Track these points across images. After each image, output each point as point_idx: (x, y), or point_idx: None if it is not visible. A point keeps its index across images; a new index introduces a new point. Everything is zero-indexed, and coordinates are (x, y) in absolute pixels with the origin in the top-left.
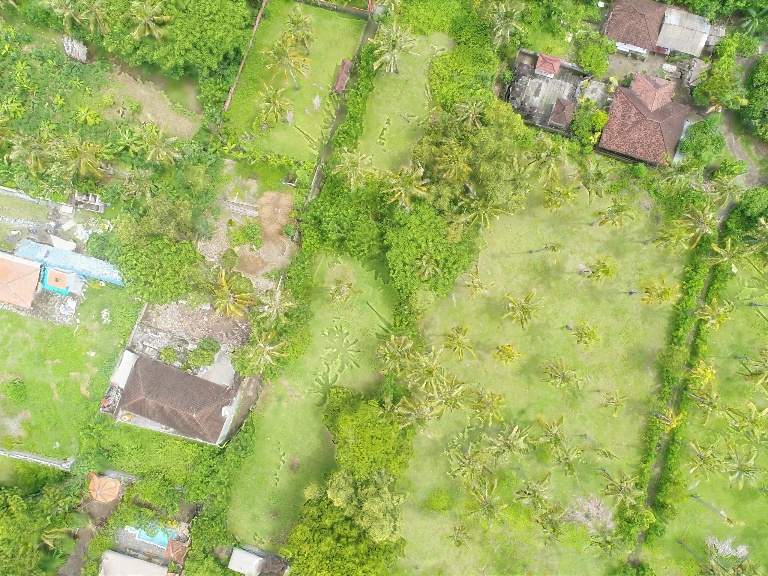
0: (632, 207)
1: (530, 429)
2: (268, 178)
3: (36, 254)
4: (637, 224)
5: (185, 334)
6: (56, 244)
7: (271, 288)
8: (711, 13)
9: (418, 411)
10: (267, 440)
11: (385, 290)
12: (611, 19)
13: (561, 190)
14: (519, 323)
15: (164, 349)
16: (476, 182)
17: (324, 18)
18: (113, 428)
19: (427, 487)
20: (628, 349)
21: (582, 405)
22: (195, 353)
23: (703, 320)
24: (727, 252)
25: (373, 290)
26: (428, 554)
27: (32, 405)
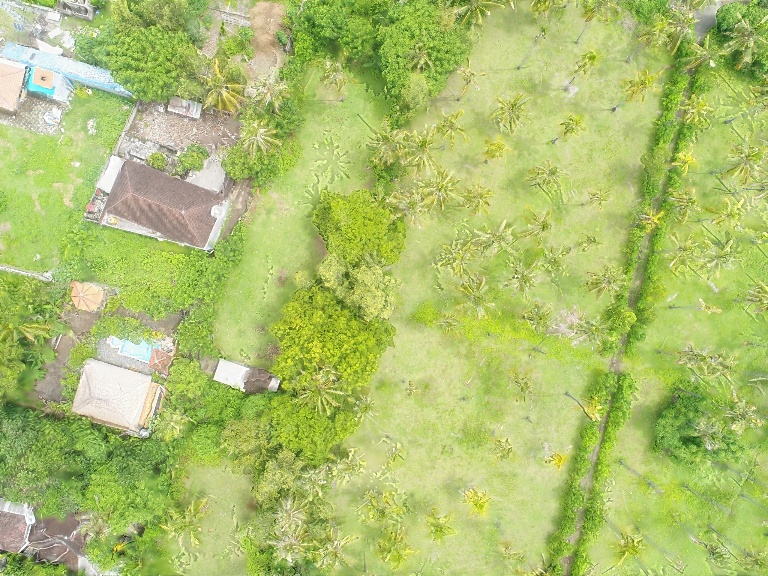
0: (615, 27)
1: (516, 242)
2: None
3: (21, 56)
4: (620, 44)
5: (173, 145)
6: (42, 48)
7: None
8: None
9: None
10: (255, 253)
11: (376, 102)
12: None
13: None
14: (506, 138)
15: (152, 153)
16: None
17: None
18: (97, 239)
19: (415, 300)
20: (610, 164)
21: (566, 219)
22: (185, 154)
23: (681, 133)
24: (706, 49)
25: (364, 103)
26: (415, 368)
27: (12, 216)
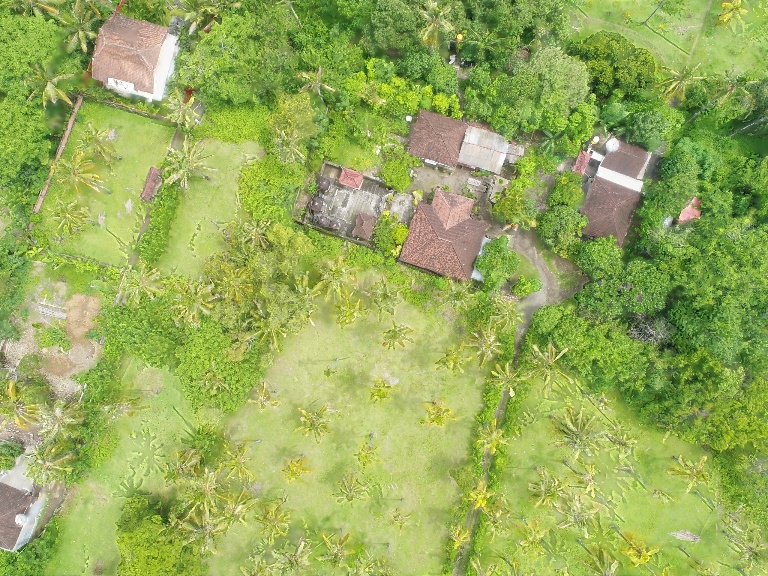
0: (436, 318)
1: (334, 536)
2: (76, 281)
3: None
4: (441, 335)
5: None
6: None
7: (78, 391)
8: (507, 134)
9: (202, 527)
10: (72, 543)
11: None
12: (414, 136)
13: (346, 310)
14: None
15: None
16: (264, 300)
17: (138, 123)
18: None
19: None
20: (431, 458)
21: (386, 513)
22: None
23: None
24: (506, 375)
25: (181, 394)
26: None
27: None
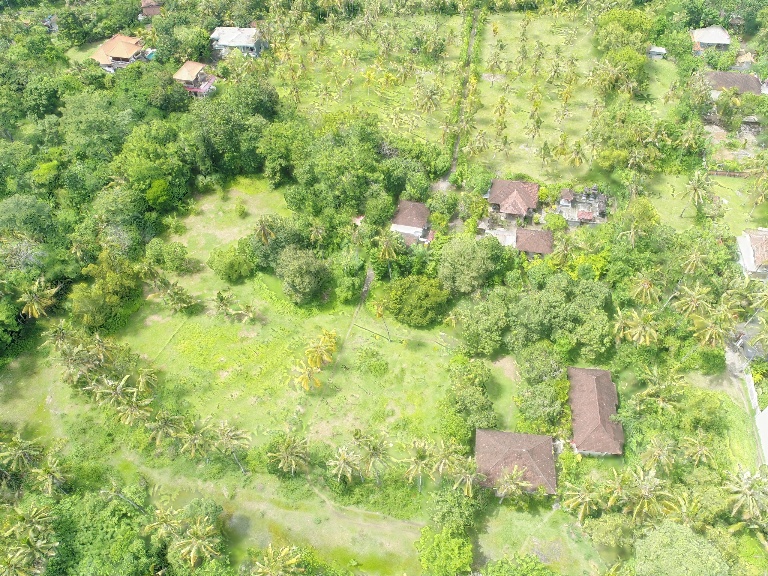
0: None
1: None
2: None
3: None
4: None
5: None
6: None
7: None
8: None
9: None
10: None
11: None
12: None
13: None
14: None
15: None
16: None
17: None
18: None
19: None
20: None
21: (509, 106)
22: None
23: None
24: None
25: None
26: None
27: None
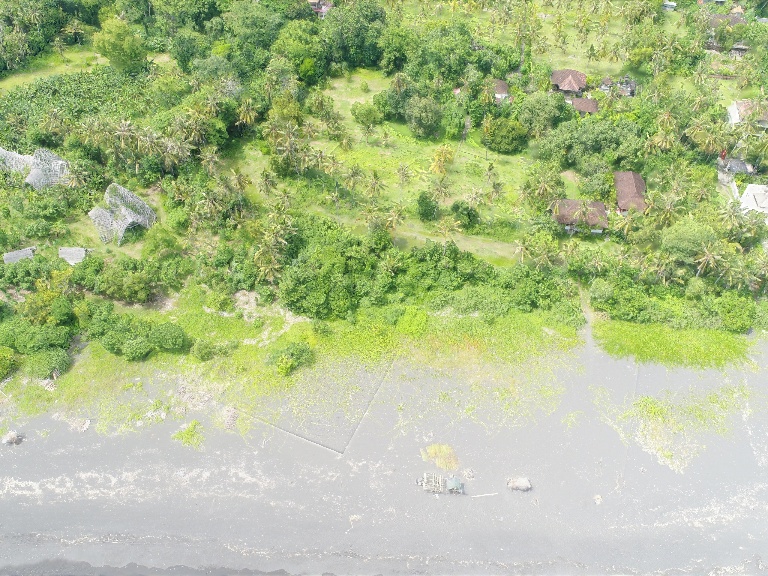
0: None
1: None
2: None
3: None
4: None
5: None
6: None
7: None
8: None
9: None
10: None
11: None
12: None
13: None
14: None
15: None
16: None
17: None
18: None
19: None
20: None
21: None
22: None
23: None
24: None
25: None
26: None
27: None
